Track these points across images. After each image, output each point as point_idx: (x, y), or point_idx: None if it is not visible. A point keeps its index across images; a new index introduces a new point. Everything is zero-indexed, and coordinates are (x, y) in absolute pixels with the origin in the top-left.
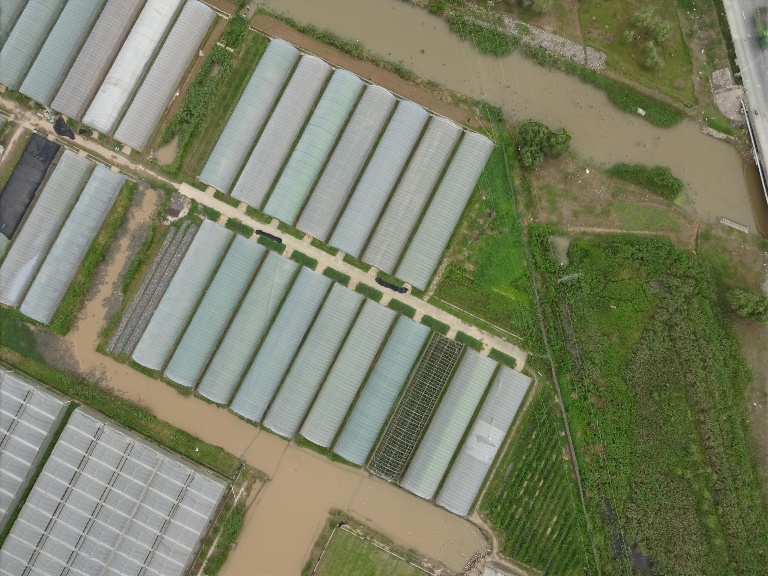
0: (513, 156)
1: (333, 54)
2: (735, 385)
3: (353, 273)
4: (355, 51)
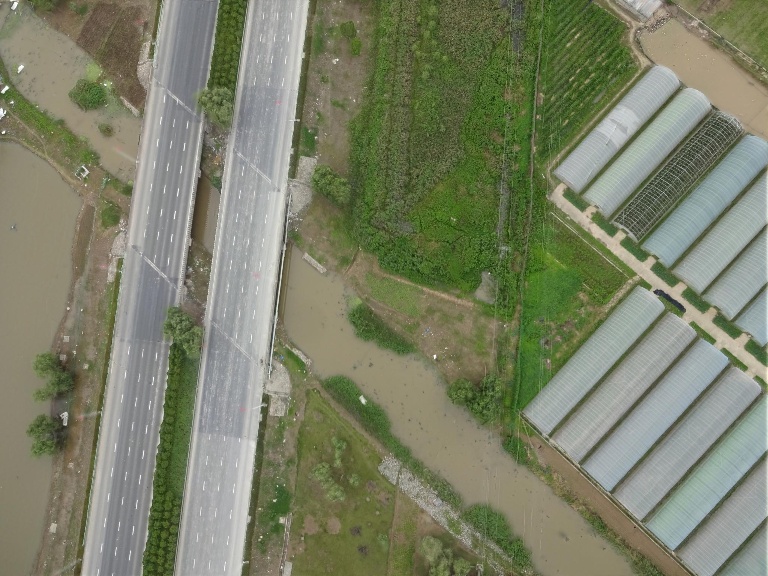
0: (506, 395)
1: (670, 571)
2: (367, 121)
3: (708, 325)
4: (646, 565)
